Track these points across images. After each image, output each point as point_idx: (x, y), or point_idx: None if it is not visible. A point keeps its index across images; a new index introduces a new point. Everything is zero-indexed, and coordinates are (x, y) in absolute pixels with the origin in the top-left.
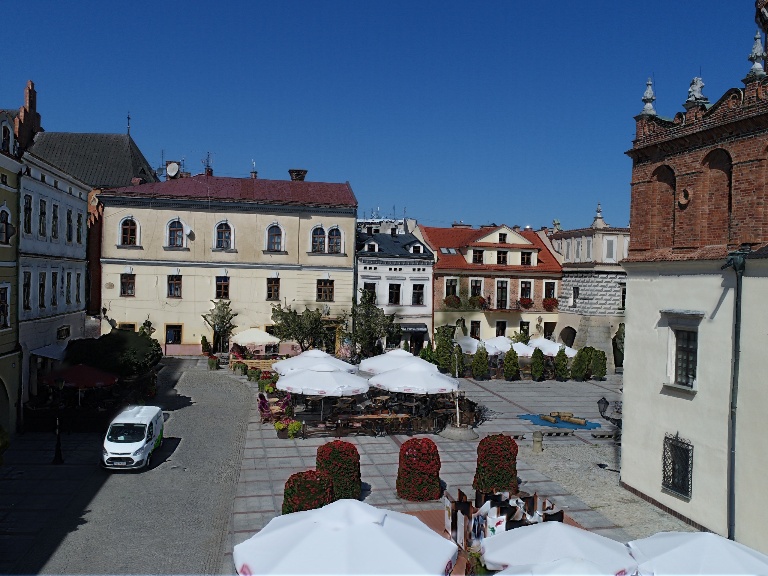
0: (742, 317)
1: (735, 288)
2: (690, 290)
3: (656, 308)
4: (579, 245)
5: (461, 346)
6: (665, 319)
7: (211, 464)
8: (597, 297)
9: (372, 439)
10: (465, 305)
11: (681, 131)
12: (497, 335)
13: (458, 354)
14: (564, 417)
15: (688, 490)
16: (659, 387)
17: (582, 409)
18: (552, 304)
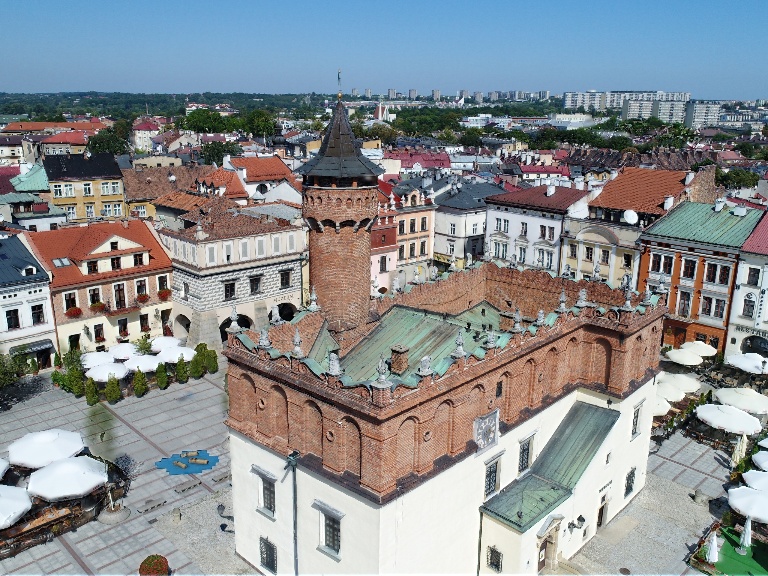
0: (297, 490)
1: (293, 472)
2: (269, 461)
3: (250, 461)
4: (185, 248)
5: (92, 373)
6: (256, 471)
7: None
8: (205, 296)
9: (44, 549)
10: (86, 313)
11: (257, 360)
12: (120, 332)
13: (91, 387)
14: (192, 460)
15: (275, 569)
16: (255, 508)
17: (203, 434)
18: (166, 295)
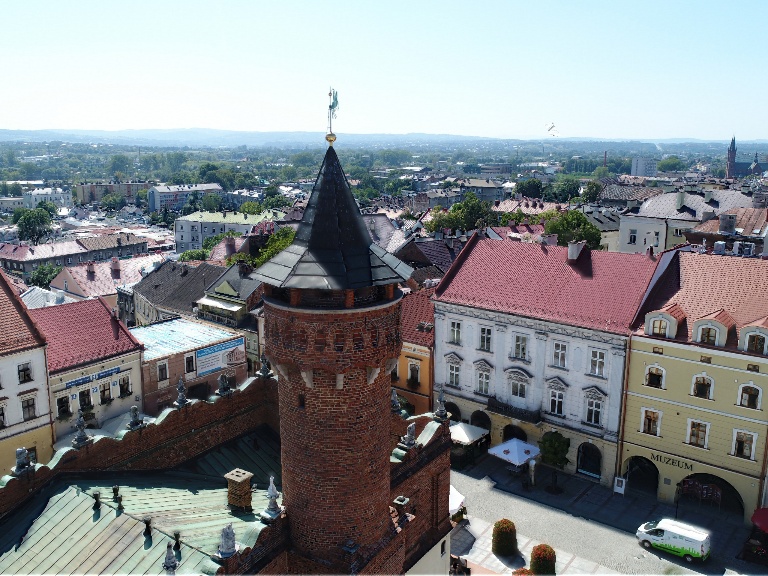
0: None
1: None
2: None
3: None
4: None
5: None
6: None
7: (643, 568)
8: None
9: None
10: None
11: None
12: None
13: None
14: None
15: None
16: None
17: None
18: None
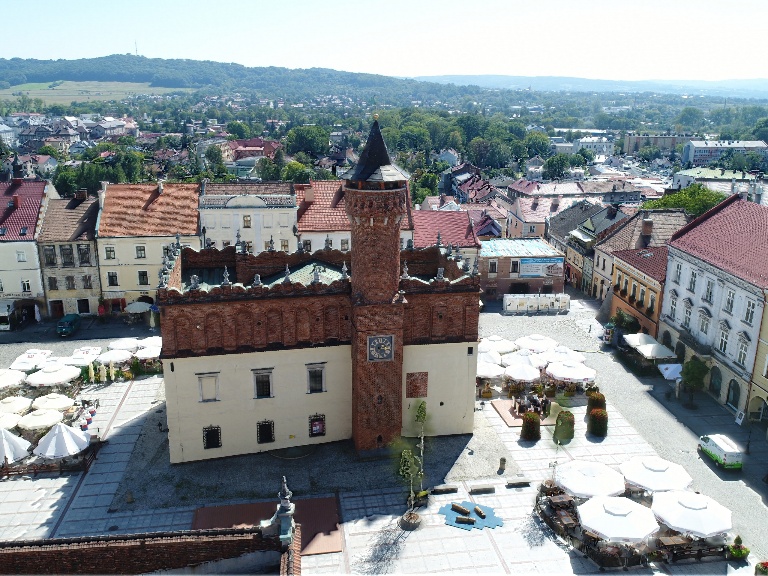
0: None
1: None
2: None
3: None
4: None
5: None
6: None
7: None
8: None
9: None
10: None
11: None
12: None
13: None
14: None
15: None
16: None
17: (437, 546)
18: None
